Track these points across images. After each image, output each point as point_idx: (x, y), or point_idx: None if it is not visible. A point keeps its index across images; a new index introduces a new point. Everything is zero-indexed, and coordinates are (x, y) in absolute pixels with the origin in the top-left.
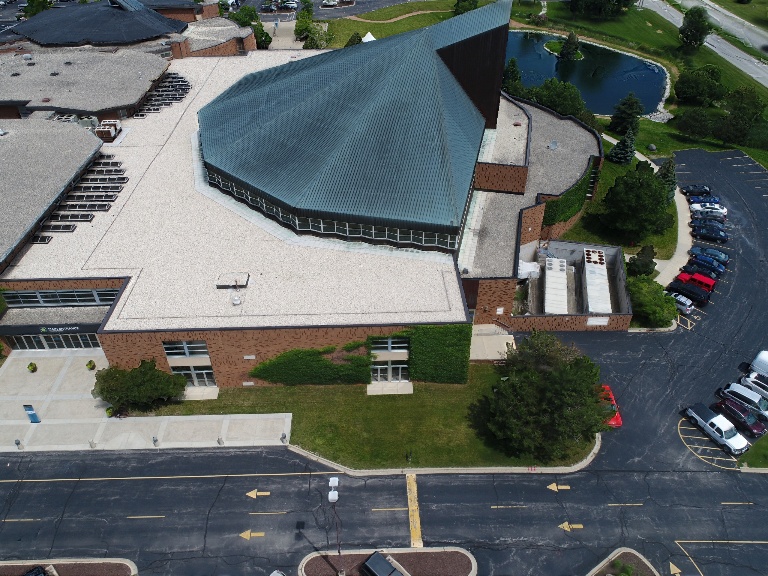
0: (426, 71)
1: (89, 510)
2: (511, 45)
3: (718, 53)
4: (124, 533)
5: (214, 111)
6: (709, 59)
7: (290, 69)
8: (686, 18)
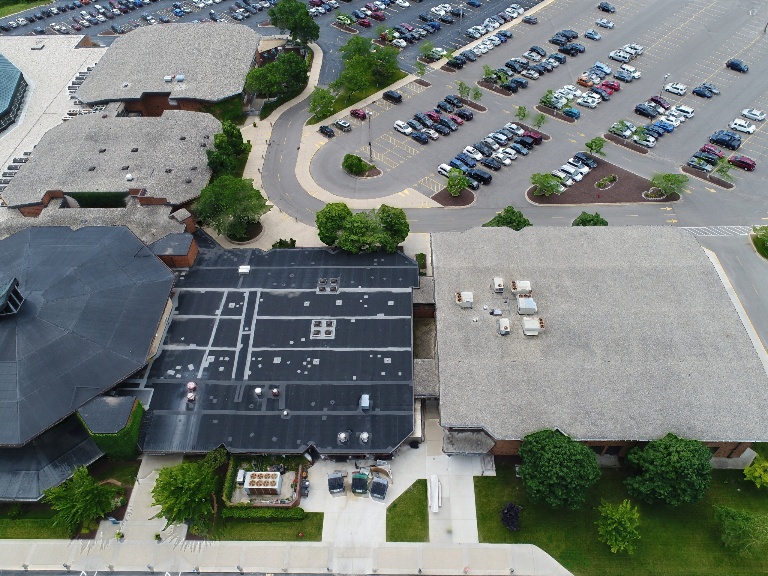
0: None
1: (108, 41)
2: None
3: None
4: None
5: None
6: None
7: None
8: None
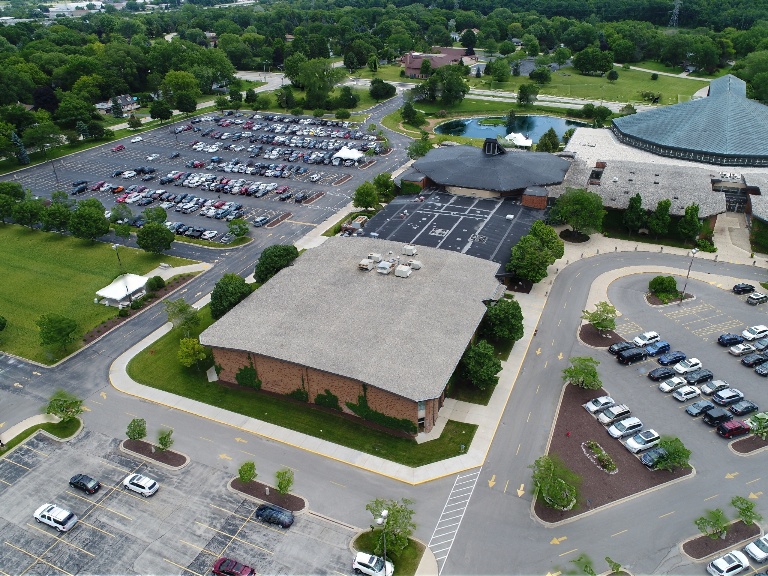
0: (760, 104)
1: None
2: (472, 129)
3: (533, 104)
4: None
5: (736, 149)
6: (544, 107)
7: (704, 127)
8: (525, 91)
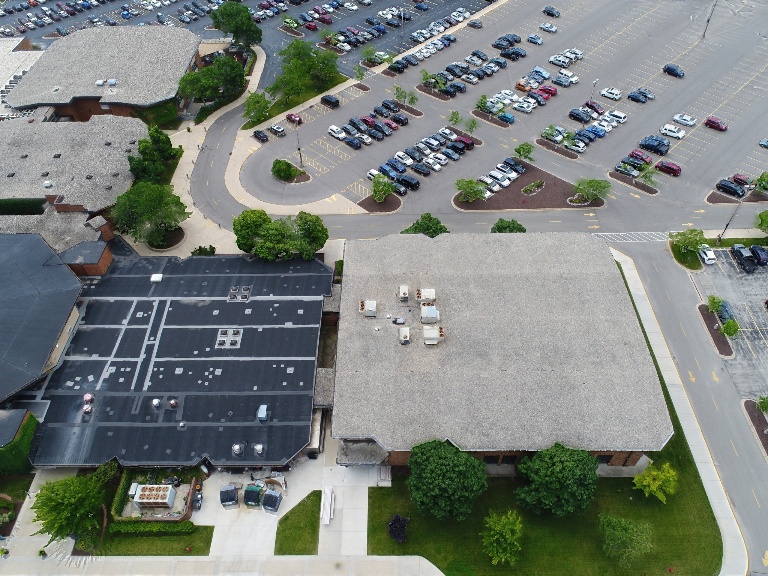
0: None
1: None
2: None
3: None
4: (44, 41)
5: None
6: None
7: None
8: None
